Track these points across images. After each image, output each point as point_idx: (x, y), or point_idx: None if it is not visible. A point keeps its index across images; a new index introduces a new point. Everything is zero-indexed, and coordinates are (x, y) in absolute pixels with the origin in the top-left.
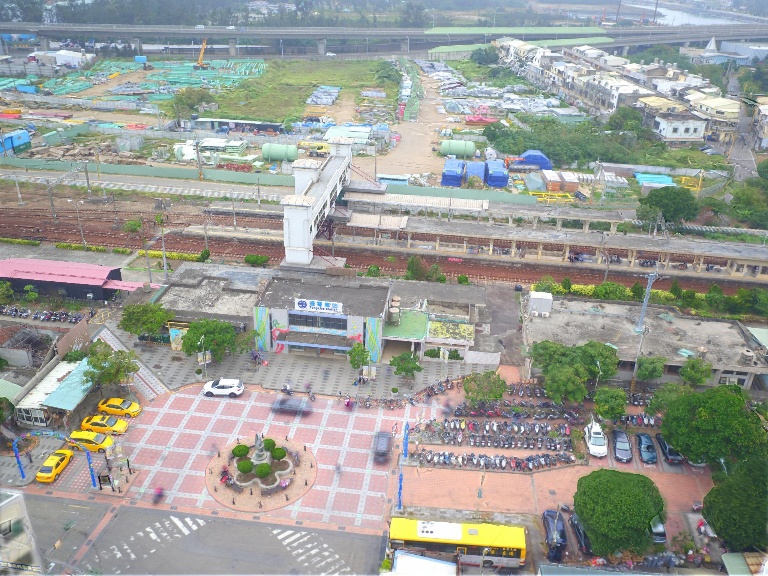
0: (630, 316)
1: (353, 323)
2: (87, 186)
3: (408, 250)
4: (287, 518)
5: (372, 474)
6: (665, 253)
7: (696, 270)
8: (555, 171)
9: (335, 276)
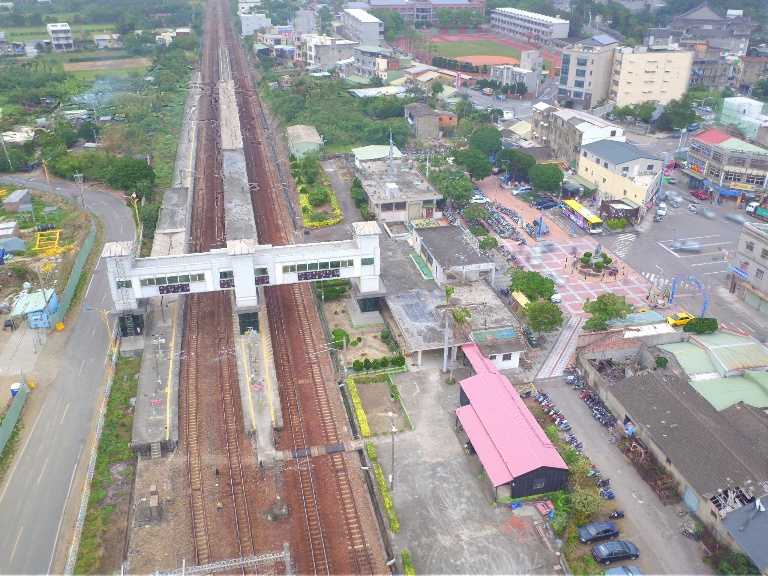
0: None
1: None
2: None
3: None
4: (612, 256)
5: None
6: None
7: None
8: None
9: None
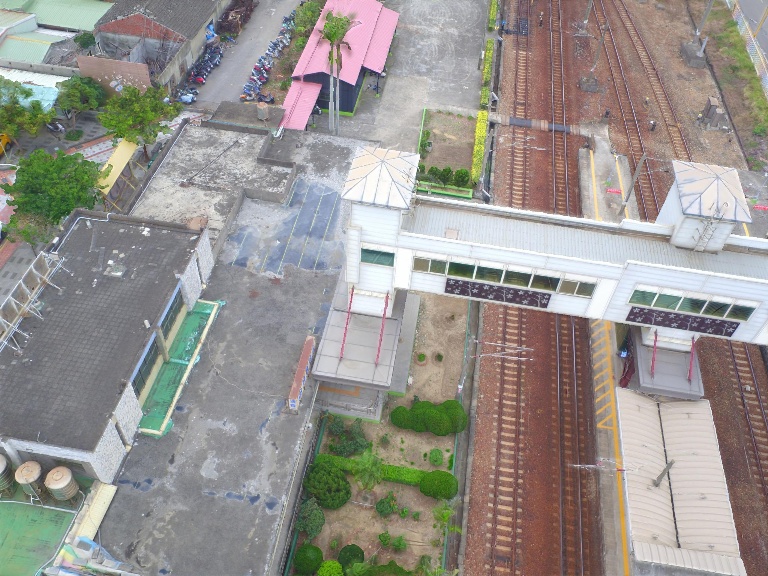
0: None
1: None
2: (741, 33)
3: None
4: None
5: None
6: None
7: None
8: None
9: None
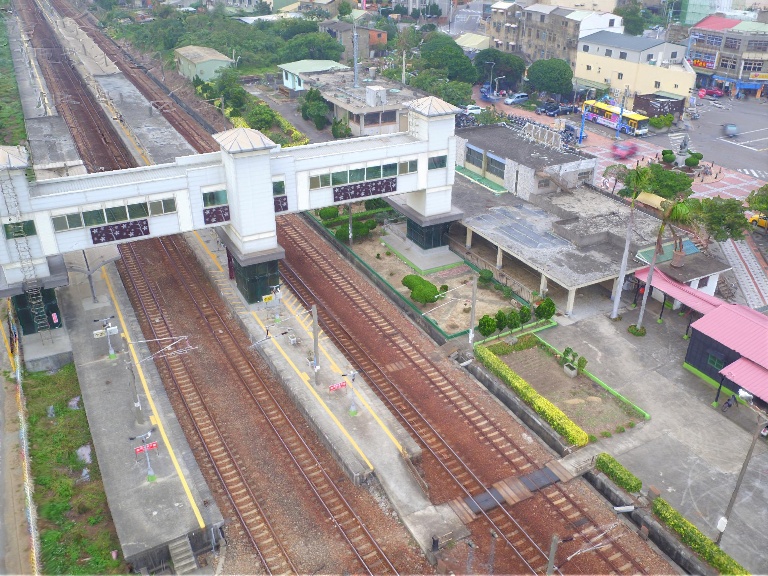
0: None
1: None
2: None
3: None
4: None
5: (609, 149)
6: None
7: None
8: None
9: None
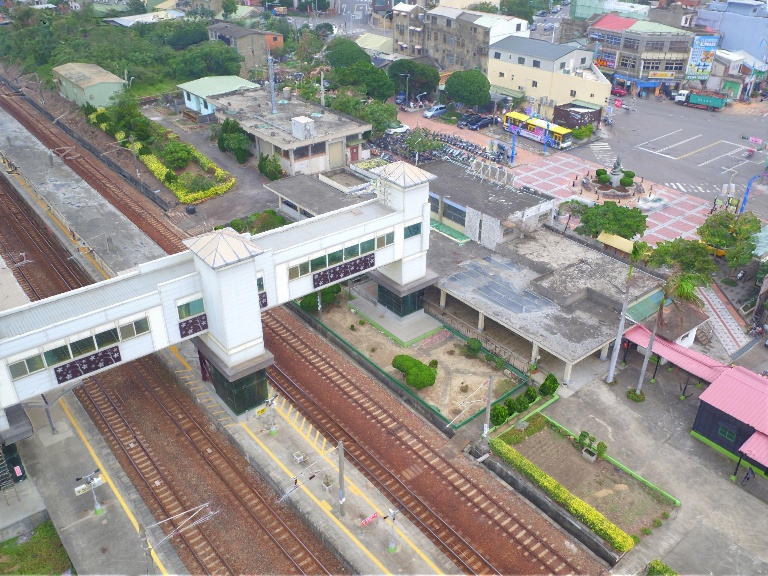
0: (257, 115)
1: None
2: None
3: None
4: None
5: (541, 168)
6: None
7: None
8: None
9: None
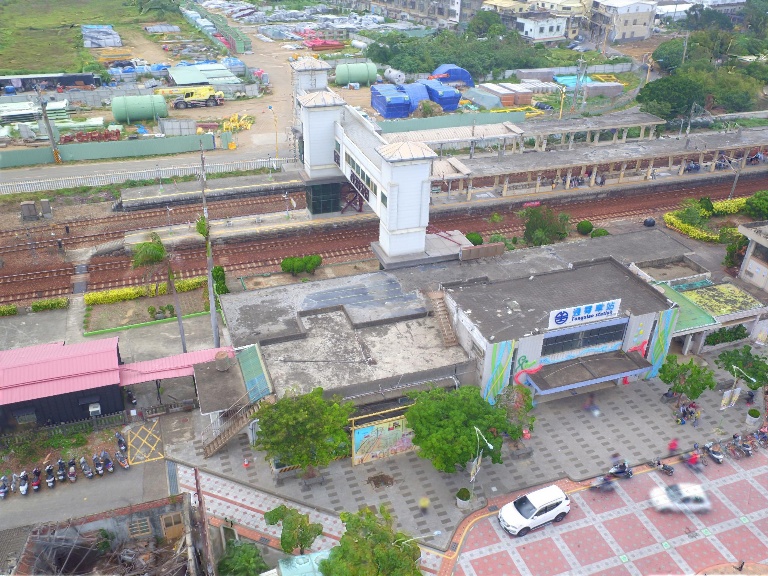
0: None
1: (639, 326)
2: None
3: (472, 204)
4: None
5: None
6: (736, 149)
7: (767, 162)
8: (493, 84)
9: (471, 260)
